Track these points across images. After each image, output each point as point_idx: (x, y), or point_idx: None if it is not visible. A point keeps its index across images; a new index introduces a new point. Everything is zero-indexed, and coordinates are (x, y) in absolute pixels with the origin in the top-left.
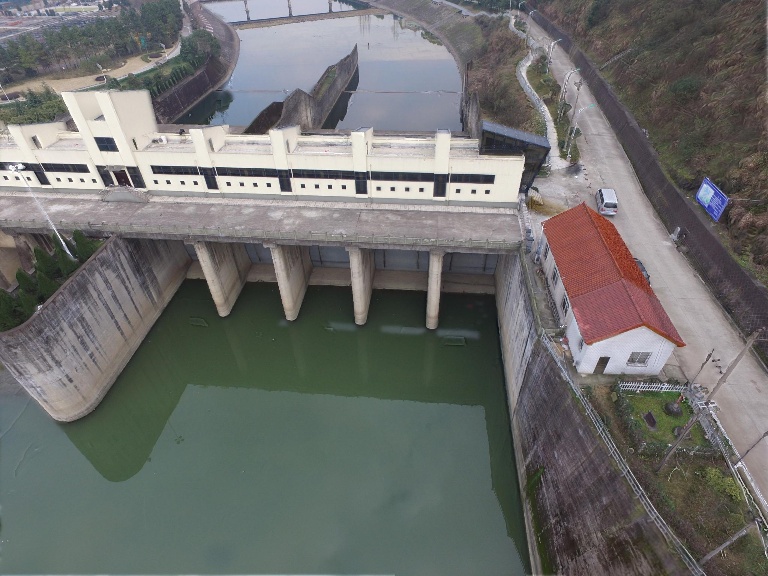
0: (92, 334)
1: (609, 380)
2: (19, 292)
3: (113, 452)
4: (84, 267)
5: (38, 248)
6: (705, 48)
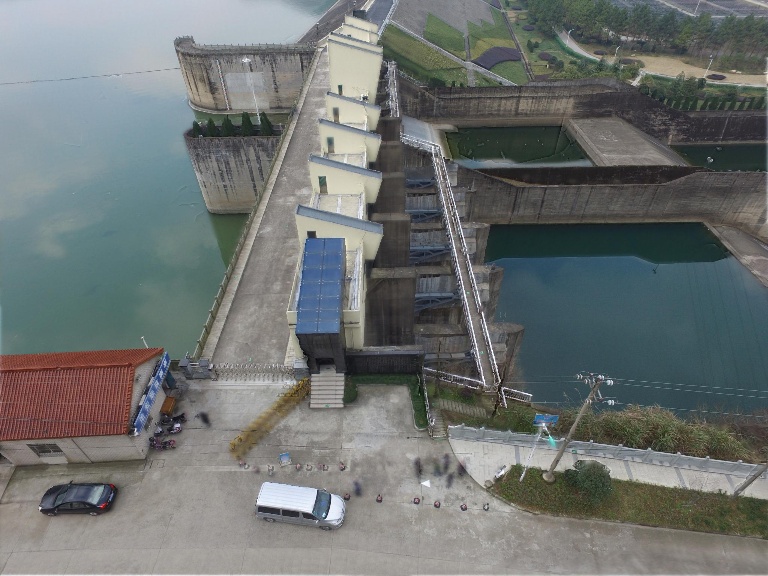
0: (231, 176)
1: None
2: (207, 124)
3: (219, 246)
4: (244, 137)
5: (244, 113)
6: None
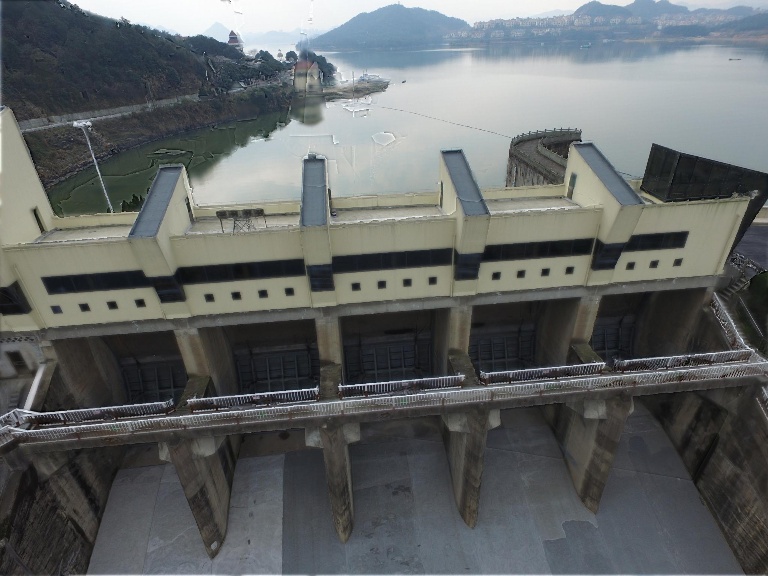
0: None
1: None
2: None
3: None
4: None
5: None
6: None
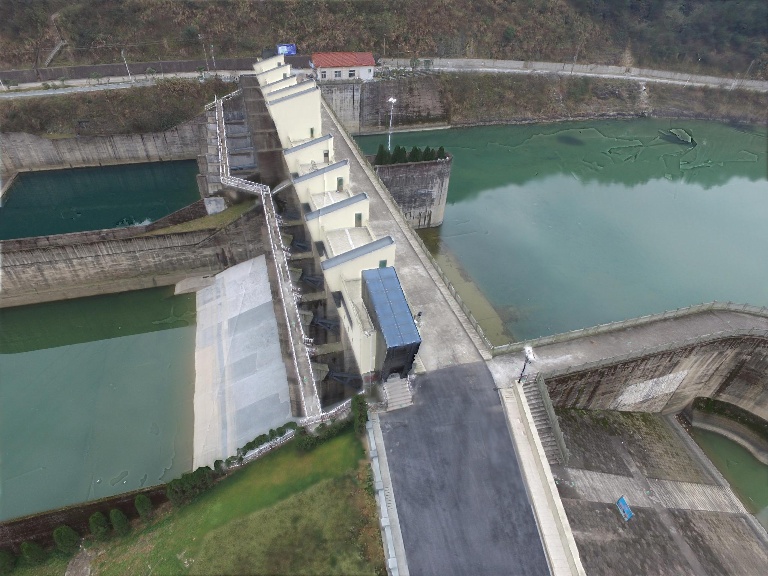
0: None
1: (373, 77)
2: None
3: None
4: None
5: None
6: (152, 17)
